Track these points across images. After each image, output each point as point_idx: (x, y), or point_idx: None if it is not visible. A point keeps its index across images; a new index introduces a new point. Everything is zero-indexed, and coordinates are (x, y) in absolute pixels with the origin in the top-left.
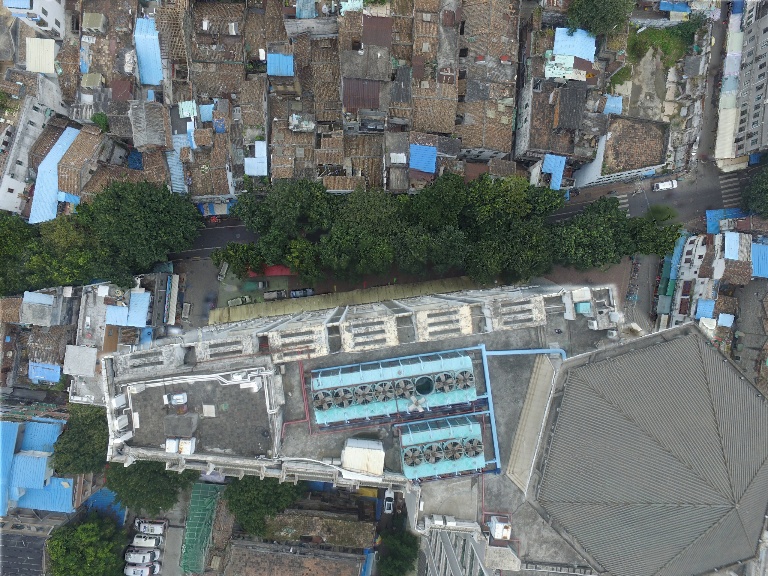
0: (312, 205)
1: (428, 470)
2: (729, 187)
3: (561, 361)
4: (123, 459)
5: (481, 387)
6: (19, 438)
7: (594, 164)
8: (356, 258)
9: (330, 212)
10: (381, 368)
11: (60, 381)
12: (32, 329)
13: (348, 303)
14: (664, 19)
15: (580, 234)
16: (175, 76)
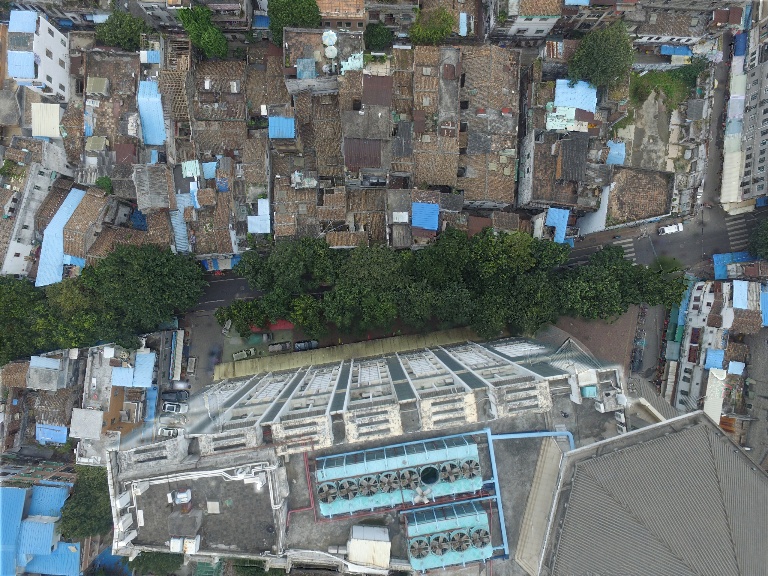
0: (315, 262)
1: (435, 561)
2: (736, 229)
3: (568, 444)
4: (128, 552)
5: (487, 471)
6: (26, 504)
7: (598, 214)
8: (360, 314)
9: (333, 267)
10: (386, 459)
11: (67, 442)
12: (39, 391)
13: (353, 356)
14: (665, 62)
15: (585, 288)
16: (178, 134)
